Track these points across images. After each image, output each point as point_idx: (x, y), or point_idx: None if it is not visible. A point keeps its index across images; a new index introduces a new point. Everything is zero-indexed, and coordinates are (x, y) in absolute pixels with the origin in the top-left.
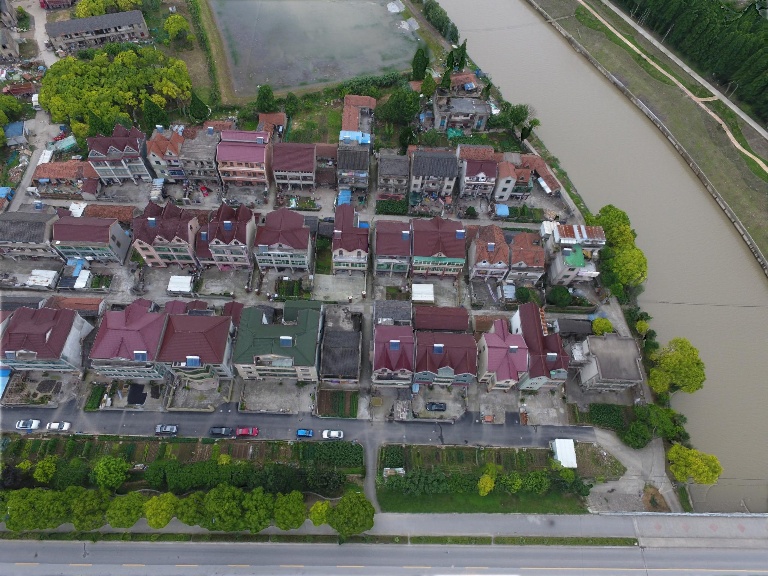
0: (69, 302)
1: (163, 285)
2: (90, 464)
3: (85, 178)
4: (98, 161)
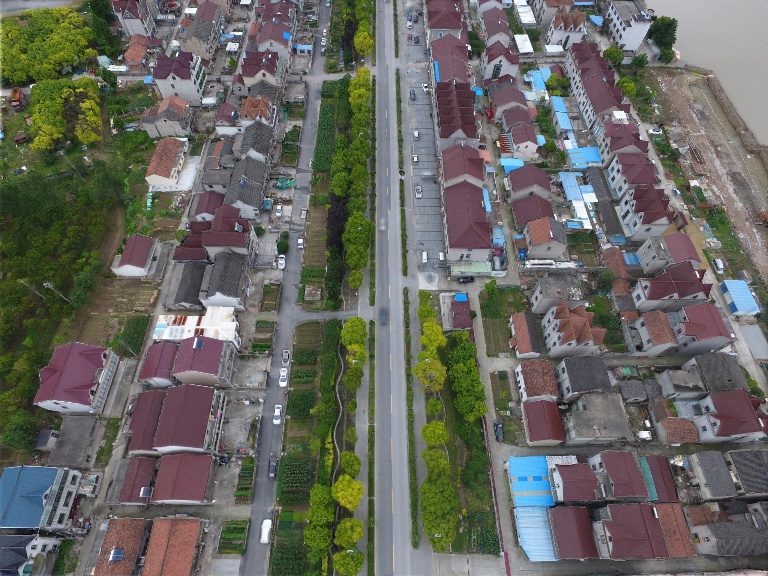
0: (253, 31)
1: (244, 13)
2: (345, 6)
3: (147, 44)
4: (144, 17)
